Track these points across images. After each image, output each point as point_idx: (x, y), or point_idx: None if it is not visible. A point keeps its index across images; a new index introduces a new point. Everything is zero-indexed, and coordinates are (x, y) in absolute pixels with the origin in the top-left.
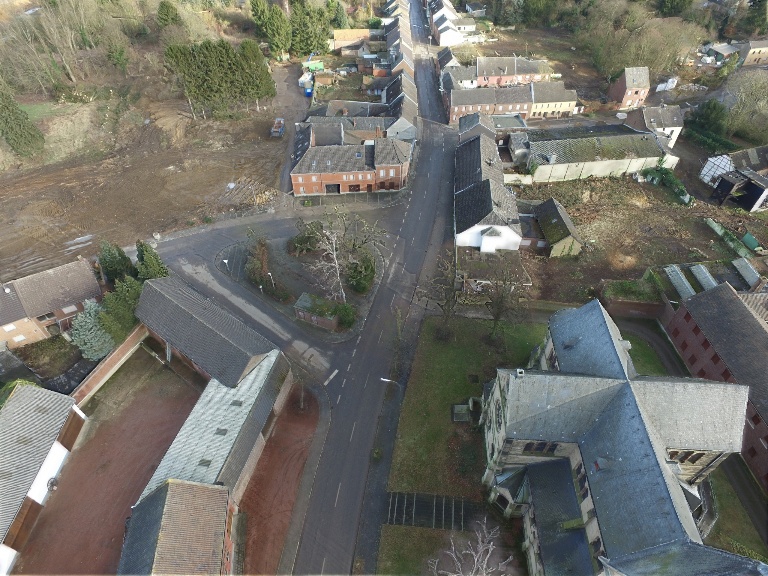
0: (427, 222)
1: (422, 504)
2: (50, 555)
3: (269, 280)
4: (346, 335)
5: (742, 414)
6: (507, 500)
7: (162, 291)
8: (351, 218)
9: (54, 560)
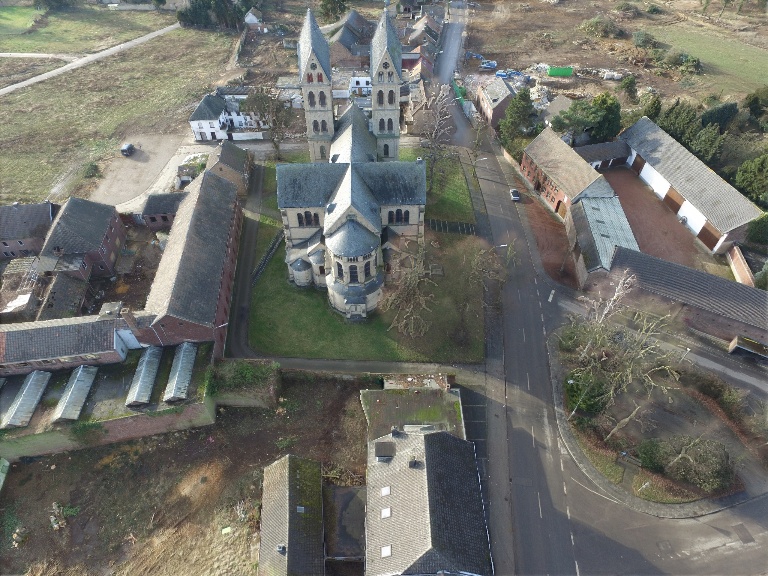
0: (531, 570)
1: (455, 230)
2: (646, 202)
3: (690, 367)
4: (560, 334)
5: None
6: None
7: (767, 293)
8: (683, 569)
9: (642, 201)
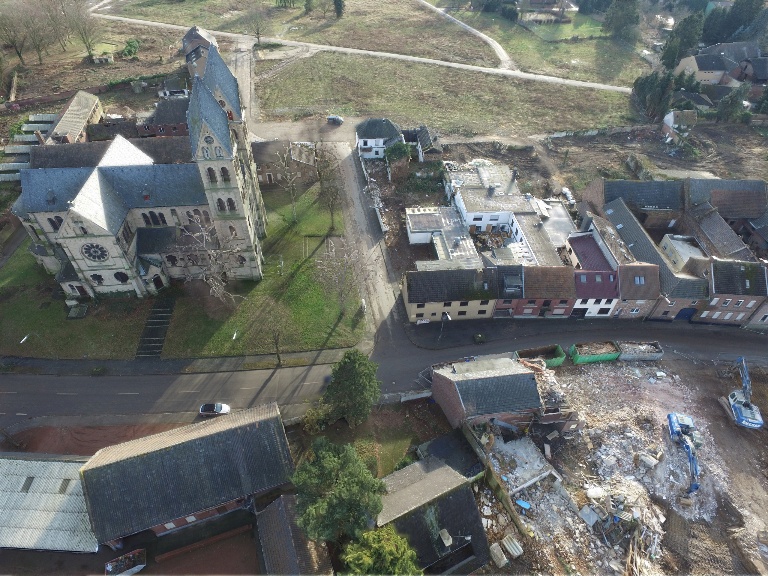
0: None
1: (150, 334)
2: None
3: None
4: None
5: (133, 146)
6: (158, 277)
7: None
8: None
9: None
